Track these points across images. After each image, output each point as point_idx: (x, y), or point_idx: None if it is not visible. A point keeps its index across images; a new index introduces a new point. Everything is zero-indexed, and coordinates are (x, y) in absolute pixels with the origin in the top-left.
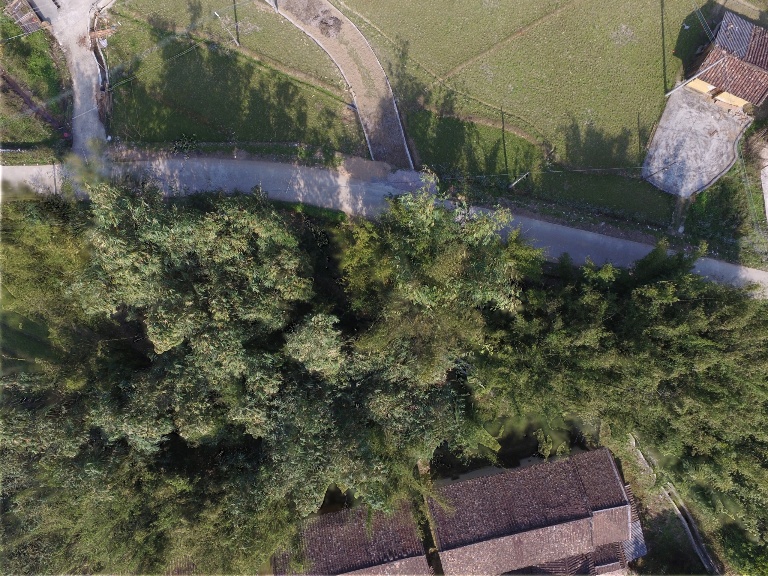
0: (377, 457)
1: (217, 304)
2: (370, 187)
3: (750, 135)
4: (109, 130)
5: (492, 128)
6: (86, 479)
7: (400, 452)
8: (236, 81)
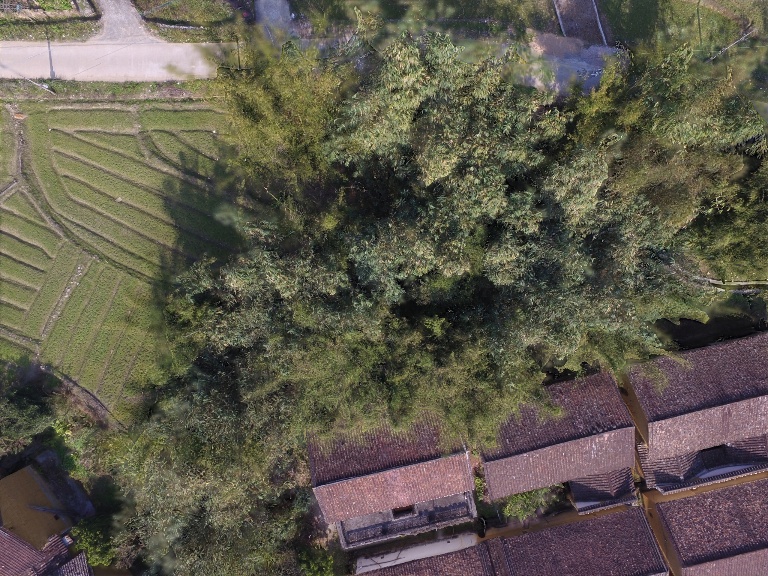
0: (630, 302)
1: (480, 138)
2: (563, 63)
3: None
4: (292, 8)
5: (686, 3)
6: (354, 313)
7: None
8: None
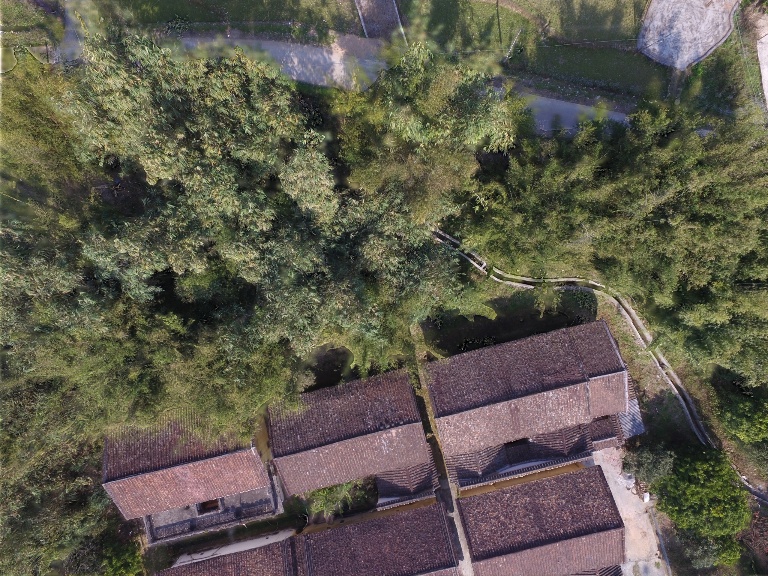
0: (371, 298)
1: (209, 138)
2: (364, 64)
3: (746, 6)
4: (102, 12)
5: (486, 3)
6: (79, 310)
7: (395, 306)
8: None
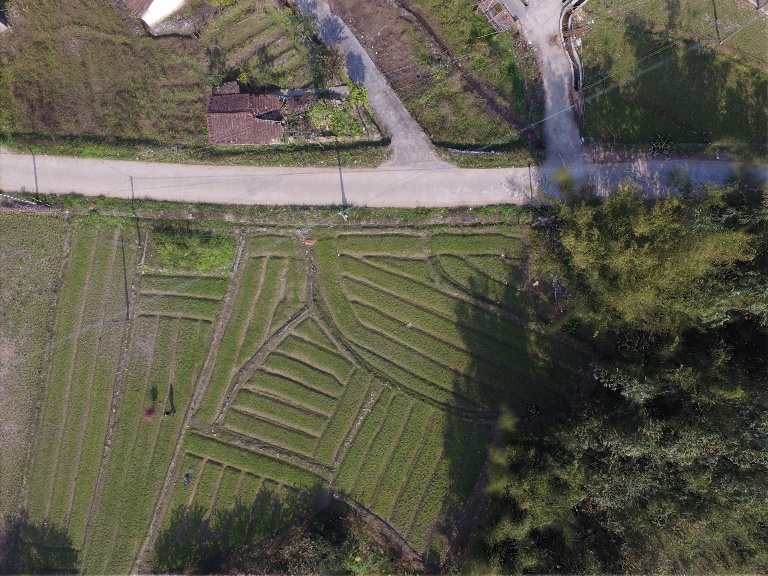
0: None
1: None
2: None
3: None
4: (581, 131)
5: None
6: None
7: None
8: (712, 80)
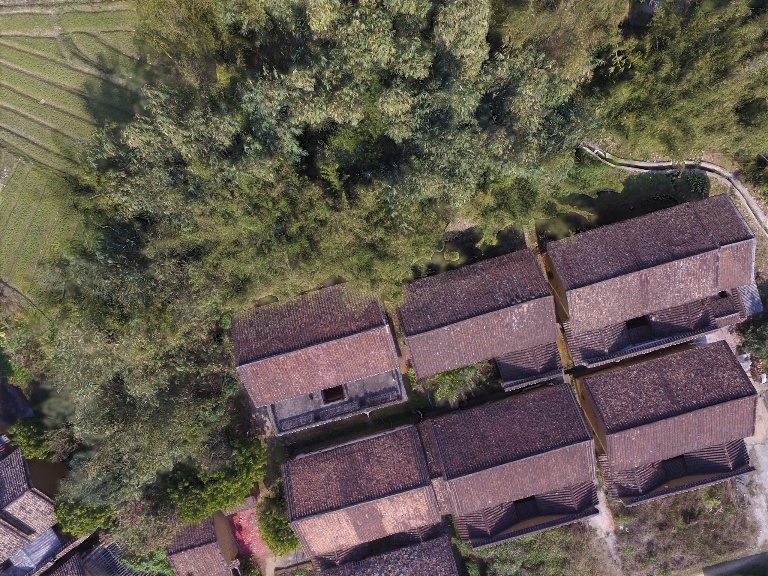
0: None
1: None
2: None
3: None
4: None
5: None
6: (245, 157)
7: None
8: None
